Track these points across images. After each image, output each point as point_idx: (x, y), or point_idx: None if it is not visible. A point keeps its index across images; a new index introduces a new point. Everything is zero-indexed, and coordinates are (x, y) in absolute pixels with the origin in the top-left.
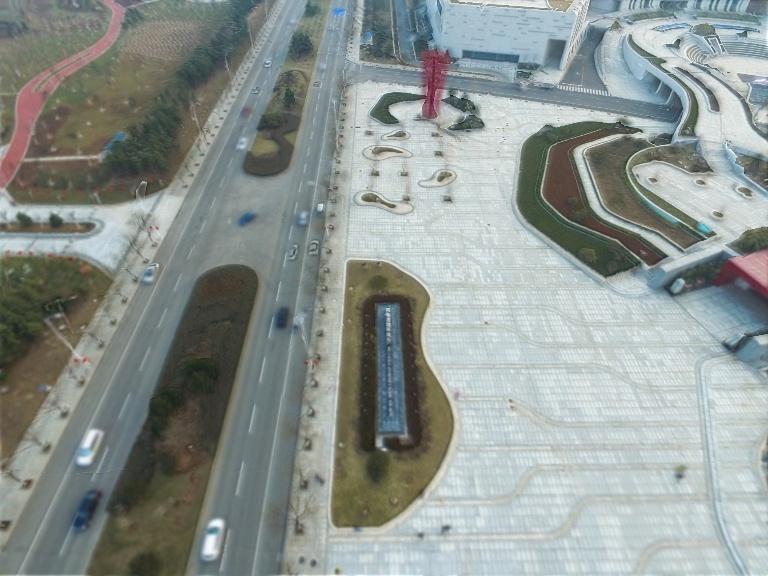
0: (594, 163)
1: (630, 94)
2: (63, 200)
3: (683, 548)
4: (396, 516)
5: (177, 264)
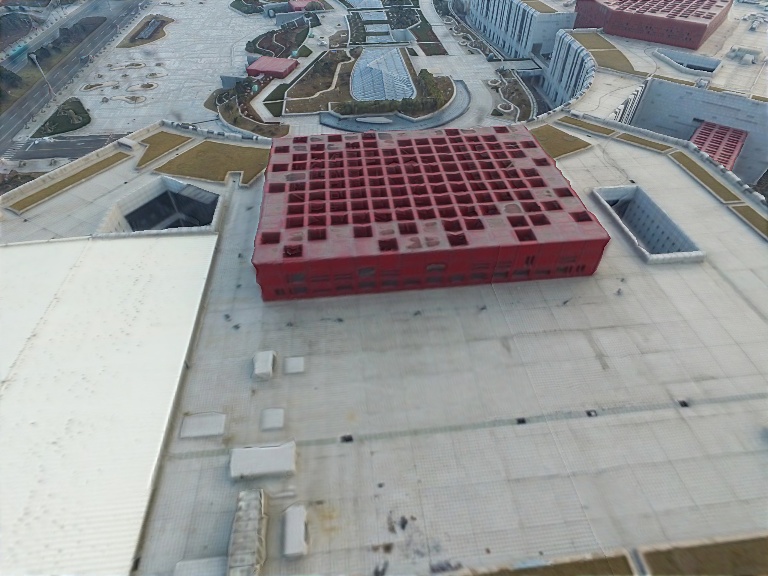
0: None
1: None
2: None
3: None
4: (136, 46)
5: (74, 18)
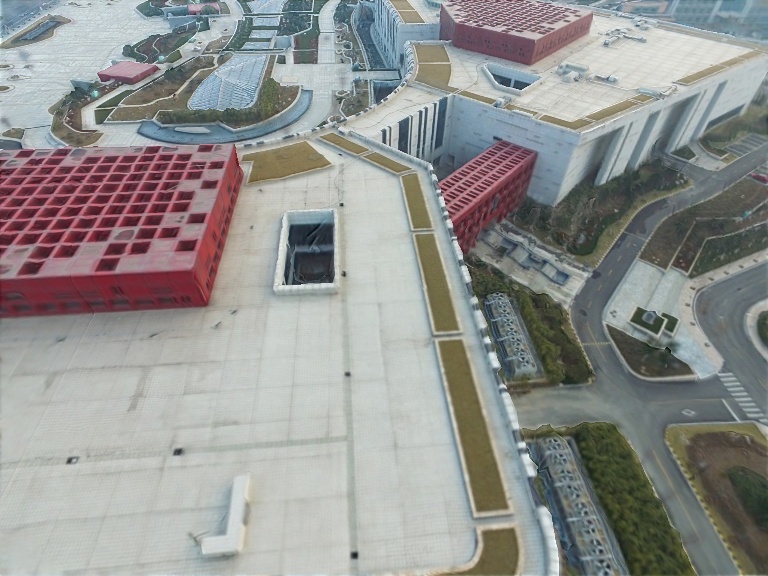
0: None
1: None
2: None
3: (99, 50)
4: (15, 47)
5: None
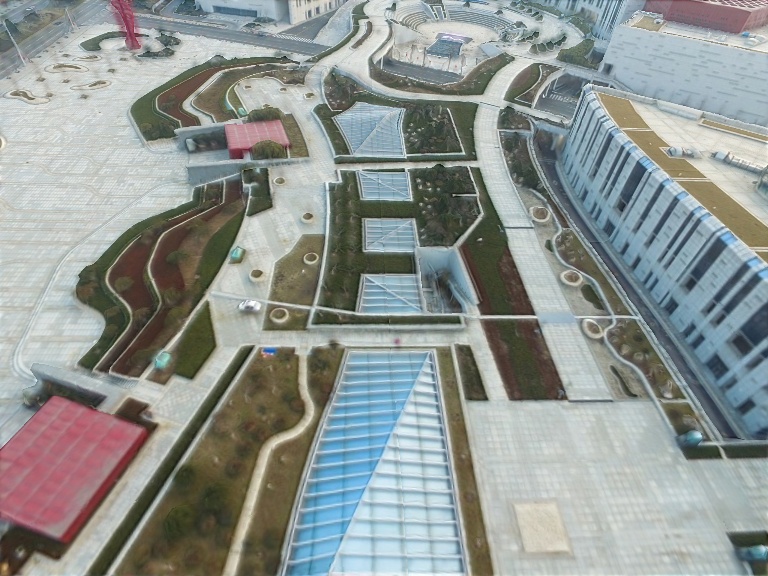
0: (221, 78)
1: (330, 42)
2: None
3: (29, 263)
4: None
5: None
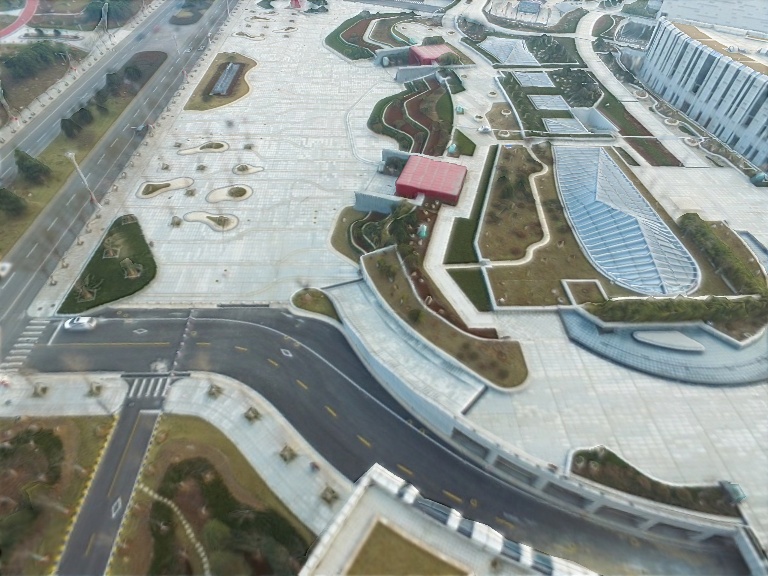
0: (379, 24)
1: (437, 4)
2: (60, 27)
3: (328, 118)
4: (211, 109)
5: (125, 51)
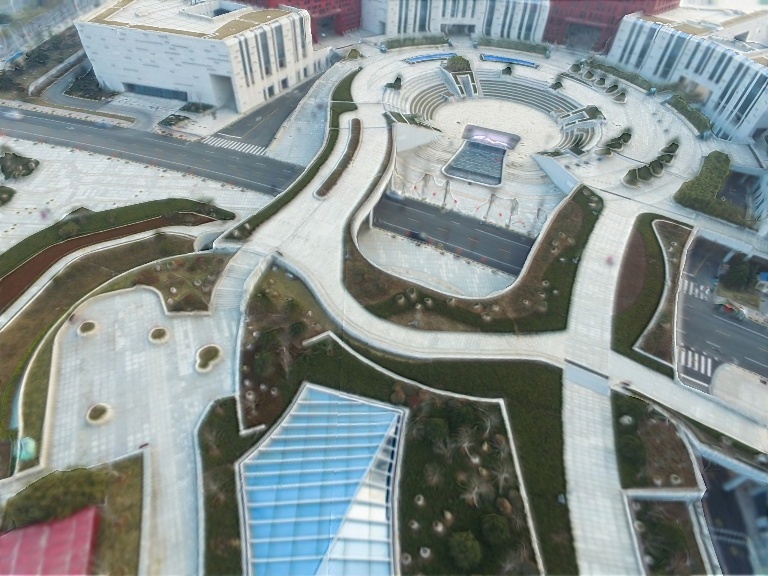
0: (54, 285)
1: (293, 153)
2: None
3: None
4: None
5: None
